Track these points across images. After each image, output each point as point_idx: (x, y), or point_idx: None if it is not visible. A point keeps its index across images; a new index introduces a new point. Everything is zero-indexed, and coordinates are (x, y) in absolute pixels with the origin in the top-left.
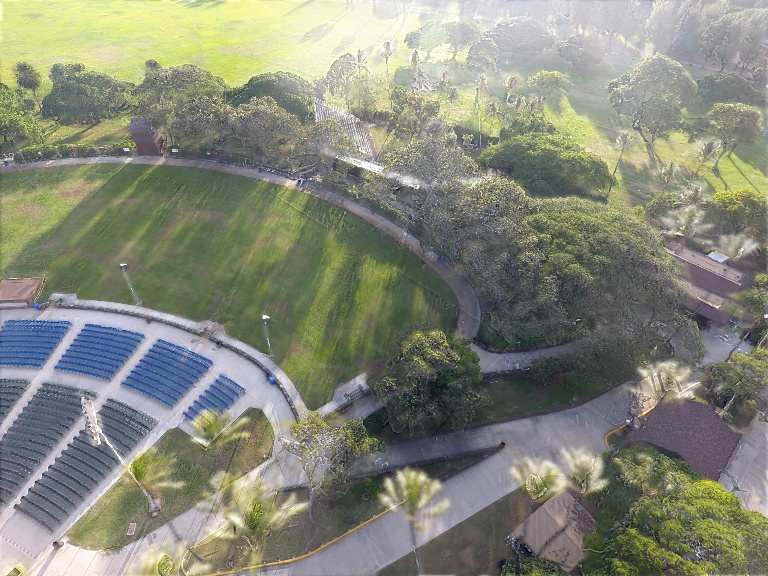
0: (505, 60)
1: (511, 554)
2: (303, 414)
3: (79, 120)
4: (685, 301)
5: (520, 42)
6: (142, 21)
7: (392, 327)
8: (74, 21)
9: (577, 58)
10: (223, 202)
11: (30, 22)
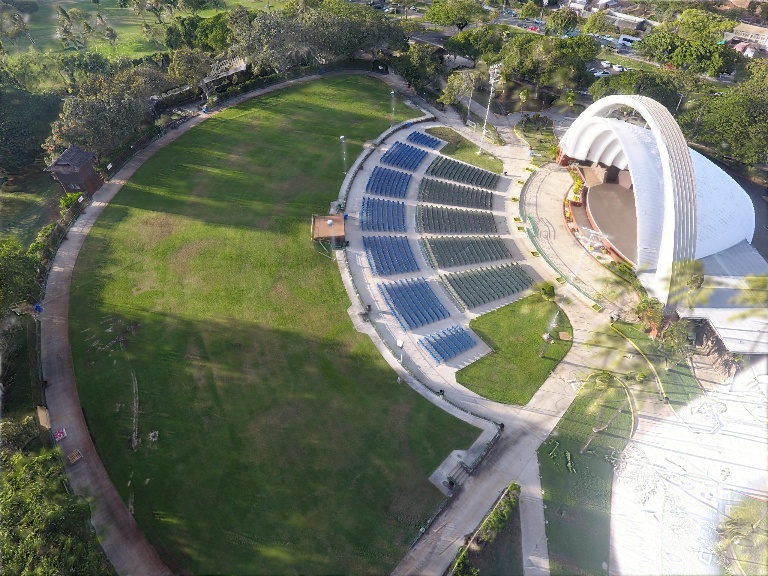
0: None
1: (474, 89)
2: (445, 92)
3: None
4: None
5: None
6: None
7: (373, 92)
8: None
9: (27, 6)
10: (222, 144)
11: None
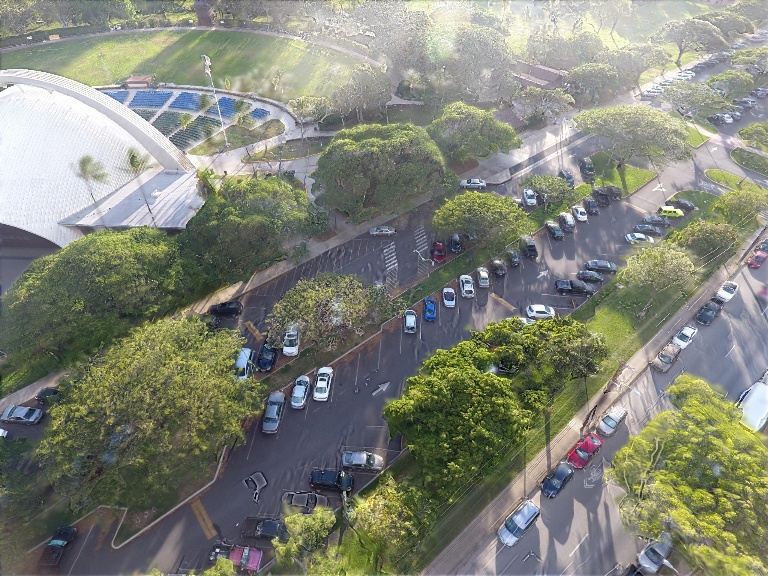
0: None
1: None
2: None
3: (155, 10)
4: (508, 63)
5: None
6: None
7: None
8: None
9: None
10: (255, 46)
11: None
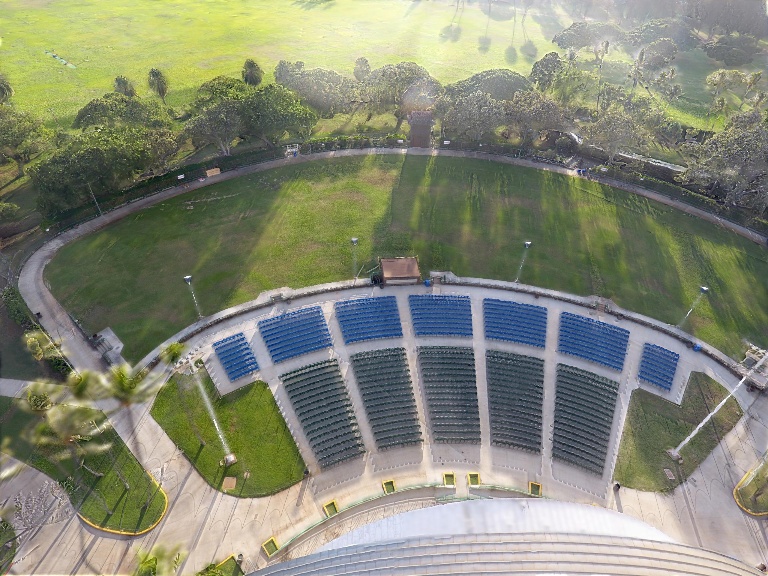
0: None
1: None
2: None
3: (323, 114)
4: None
5: None
6: (275, 22)
7: None
8: (211, 22)
9: (733, 58)
10: (523, 190)
11: (170, 23)
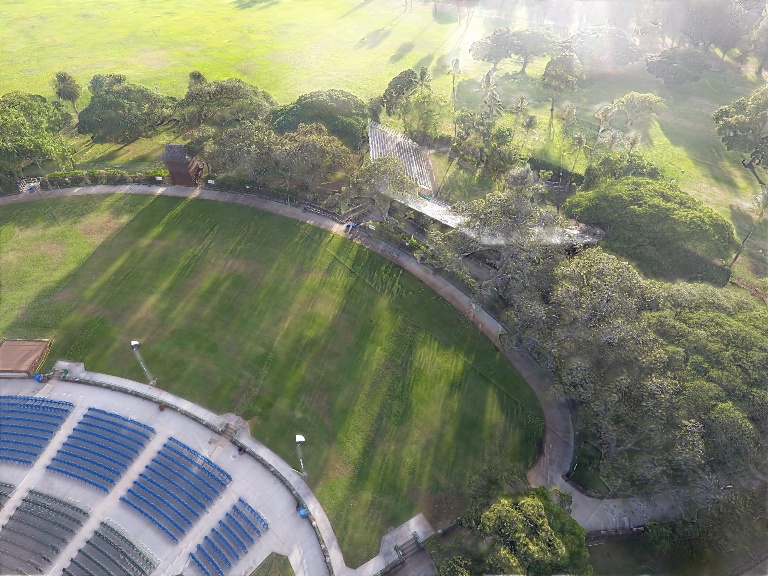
0: (582, 74)
1: None
2: None
3: (114, 139)
4: None
5: (602, 55)
6: (193, 23)
7: (458, 445)
8: (126, 22)
9: (670, 75)
10: (260, 249)
11: (83, 23)
